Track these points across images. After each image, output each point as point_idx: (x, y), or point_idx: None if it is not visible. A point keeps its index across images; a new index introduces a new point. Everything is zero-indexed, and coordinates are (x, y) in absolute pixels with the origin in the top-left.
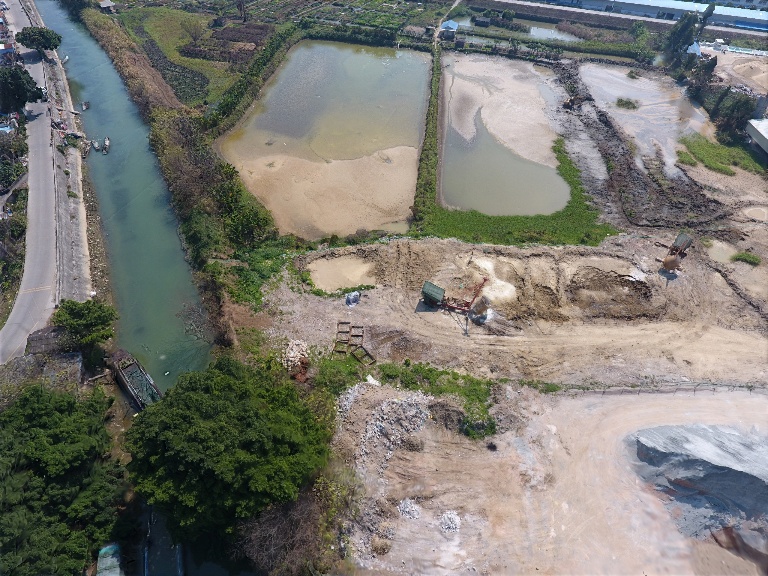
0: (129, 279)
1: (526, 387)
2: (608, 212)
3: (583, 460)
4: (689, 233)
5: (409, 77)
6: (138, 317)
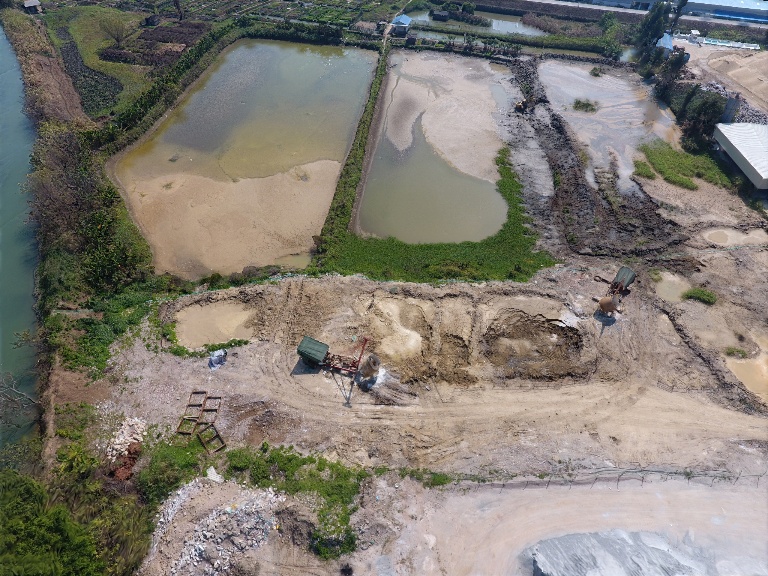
0: None
1: (407, 479)
2: (547, 237)
3: None
4: (636, 264)
5: (349, 79)
6: None
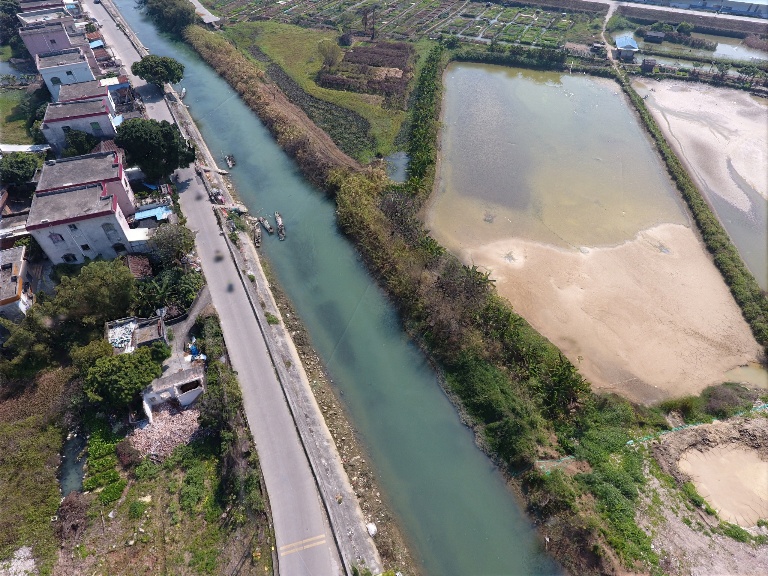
0: (407, 488)
1: None
2: None
3: None
4: None
5: (608, 114)
6: (448, 572)
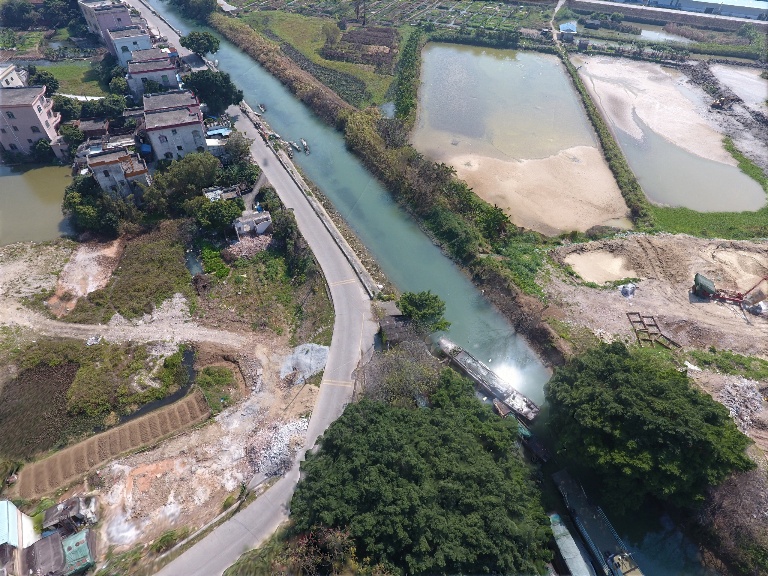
0: (401, 273)
1: None
2: None
3: None
4: None
5: (549, 79)
6: None
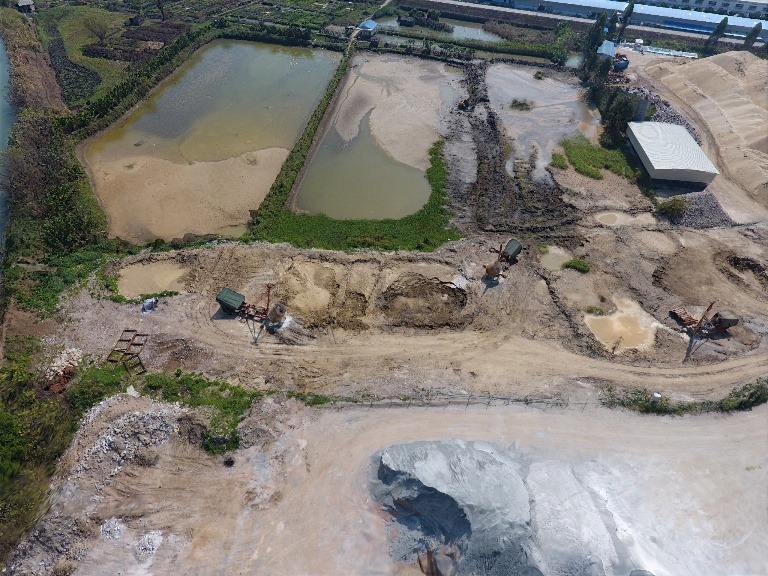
0: None
1: (293, 399)
2: (460, 216)
3: (320, 477)
4: (529, 239)
5: (311, 77)
6: None
